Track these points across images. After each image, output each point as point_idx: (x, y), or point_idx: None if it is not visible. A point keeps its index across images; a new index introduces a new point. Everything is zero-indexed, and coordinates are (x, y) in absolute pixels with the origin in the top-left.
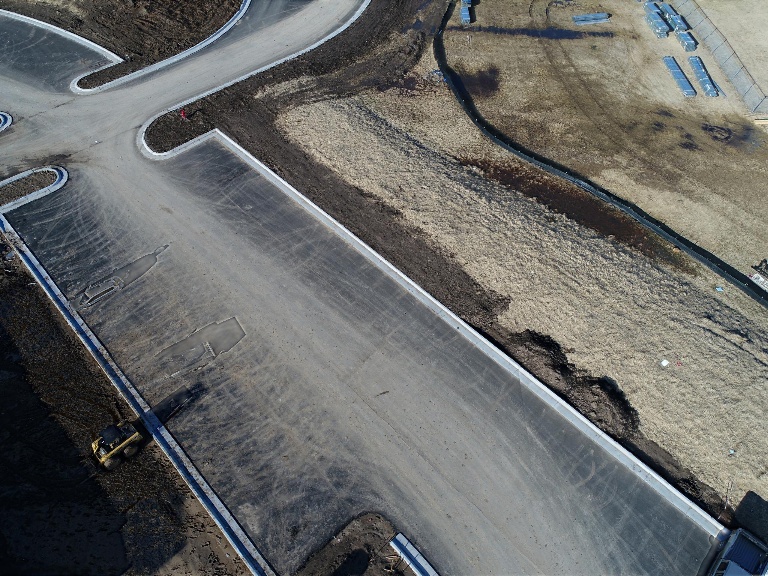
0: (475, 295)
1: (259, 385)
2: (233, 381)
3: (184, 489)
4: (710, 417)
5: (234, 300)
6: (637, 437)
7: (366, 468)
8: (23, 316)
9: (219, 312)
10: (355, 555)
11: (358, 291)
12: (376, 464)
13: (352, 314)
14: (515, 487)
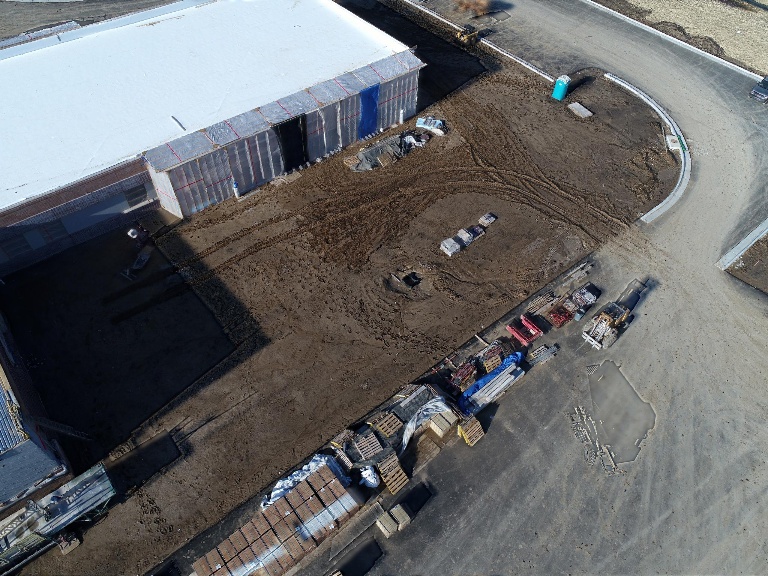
0: (632, 8)
1: (525, 31)
2: (511, 29)
3: (502, 55)
4: (762, 48)
5: (500, 5)
6: (723, 56)
7: (587, 56)
8: (393, 3)
9: (494, 8)
10: (588, 77)
11: (567, 5)
12: (592, 55)
13: (566, 13)
14: (662, 65)
